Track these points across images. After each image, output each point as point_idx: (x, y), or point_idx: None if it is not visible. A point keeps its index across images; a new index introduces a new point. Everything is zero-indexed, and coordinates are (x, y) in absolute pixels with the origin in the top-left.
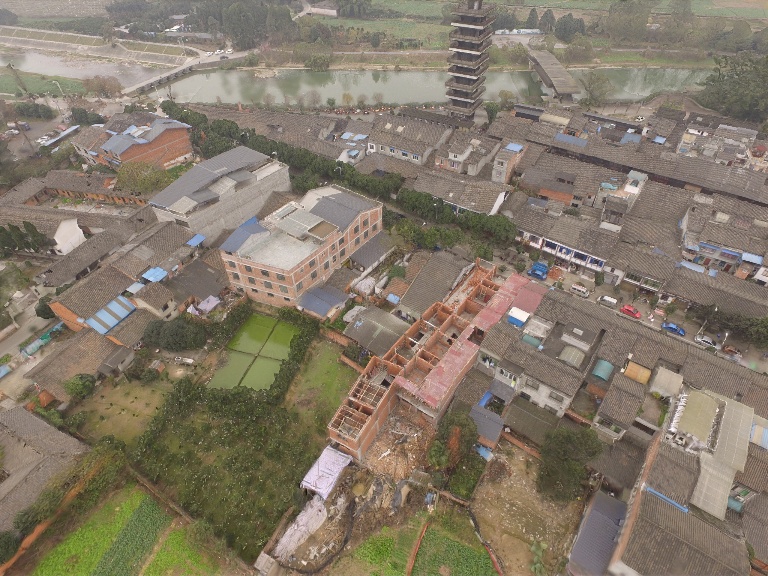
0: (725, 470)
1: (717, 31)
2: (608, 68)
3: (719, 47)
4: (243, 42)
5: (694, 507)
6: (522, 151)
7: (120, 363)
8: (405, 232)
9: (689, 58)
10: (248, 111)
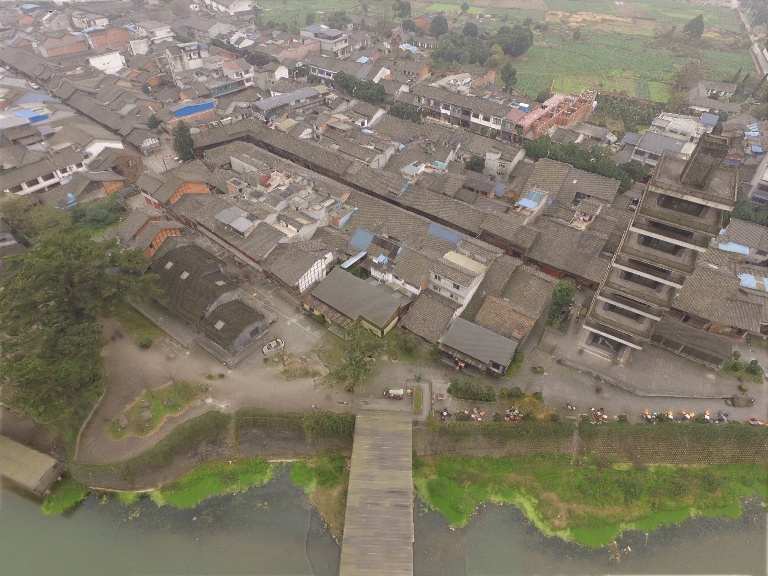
0: None
1: None
2: None
3: None
4: None
5: None
6: None
7: None
8: None
9: None
10: None
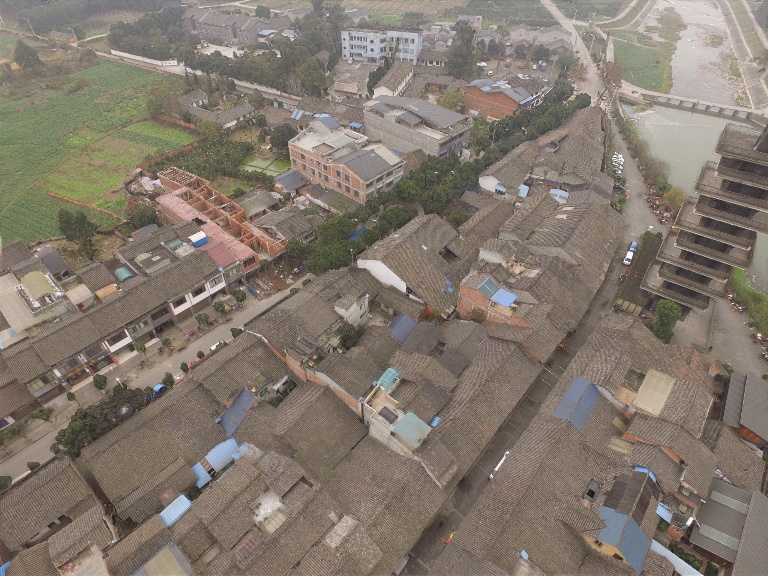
0: (5, 293)
1: None
2: None
3: None
4: None
5: (7, 273)
6: (511, 316)
7: (272, 127)
8: None
9: None
10: None
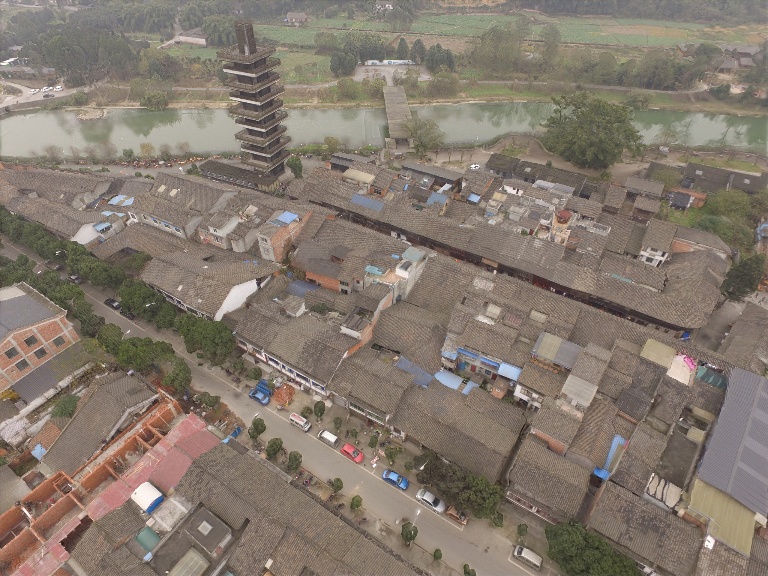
0: None
1: (583, 63)
2: (472, 103)
3: (585, 80)
4: (74, 78)
5: None
6: (301, 220)
7: None
8: (92, 348)
9: (558, 91)
10: (21, 167)
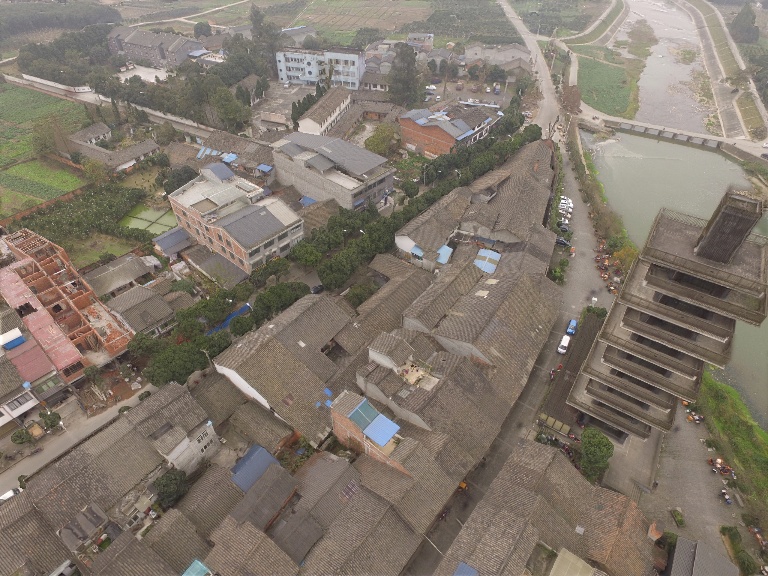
0: None
1: None
2: None
3: None
4: None
5: None
6: None
7: None
8: None
9: None
10: None
